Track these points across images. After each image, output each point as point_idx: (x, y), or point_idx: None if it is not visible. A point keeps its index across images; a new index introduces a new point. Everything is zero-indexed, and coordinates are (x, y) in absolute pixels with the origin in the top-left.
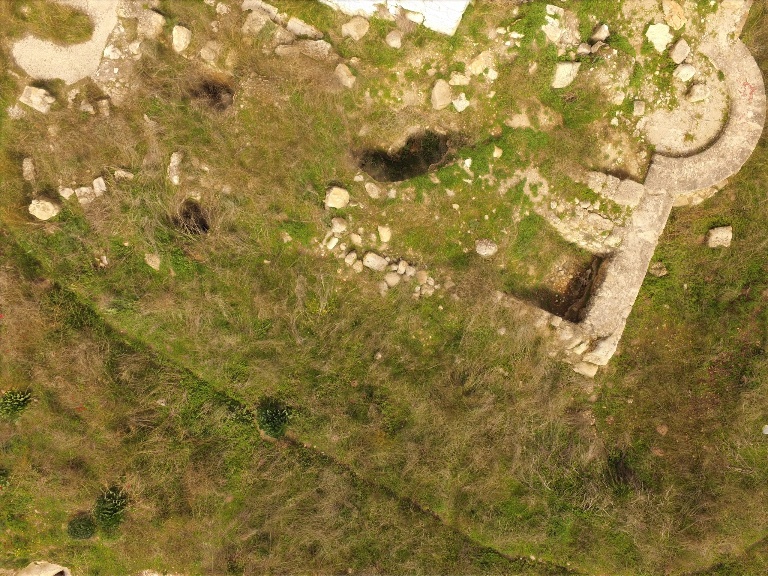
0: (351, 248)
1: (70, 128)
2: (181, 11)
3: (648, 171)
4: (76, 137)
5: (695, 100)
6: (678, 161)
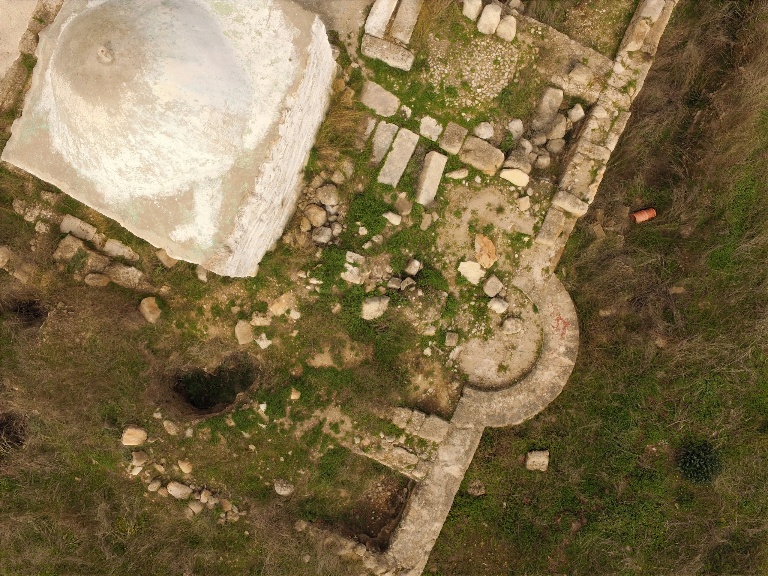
0: (157, 474)
1: None
2: (0, 228)
3: (457, 404)
4: None
5: None
6: (487, 395)
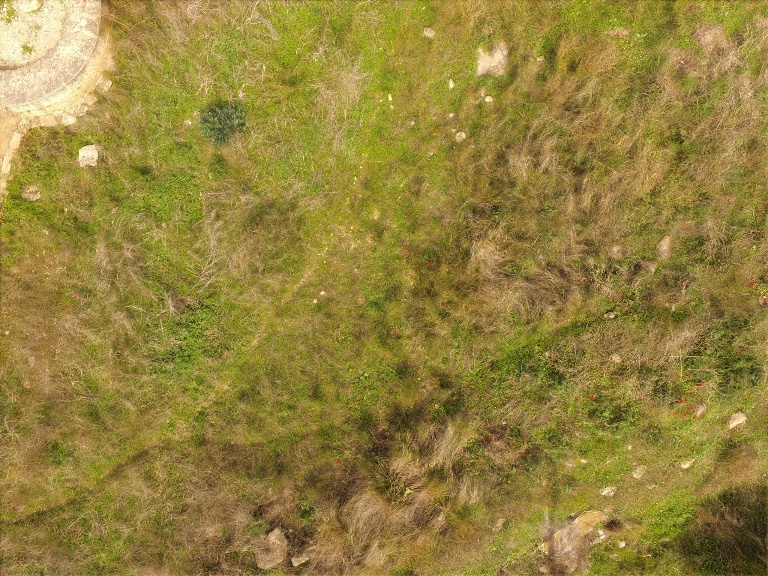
0: None
1: None
2: None
3: None
4: None
5: (27, 10)
6: (5, 73)
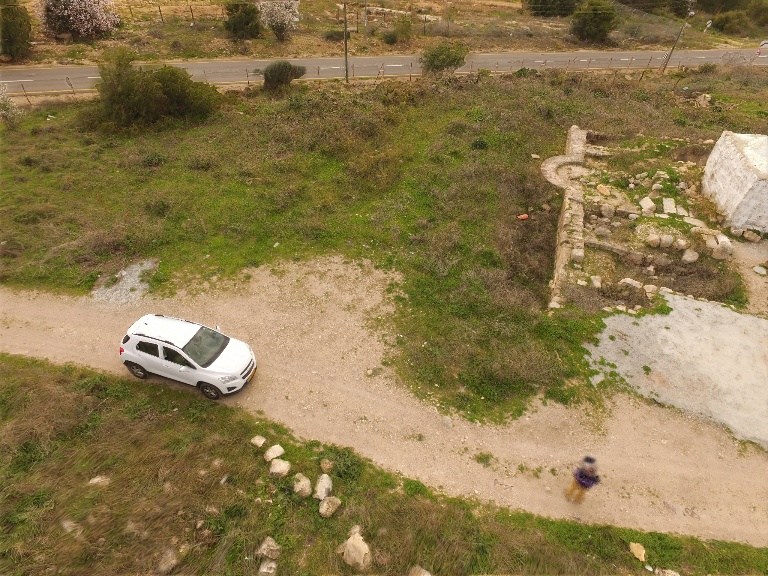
0: None
1: None
2: None
3: None
4: None
5: None
6: None
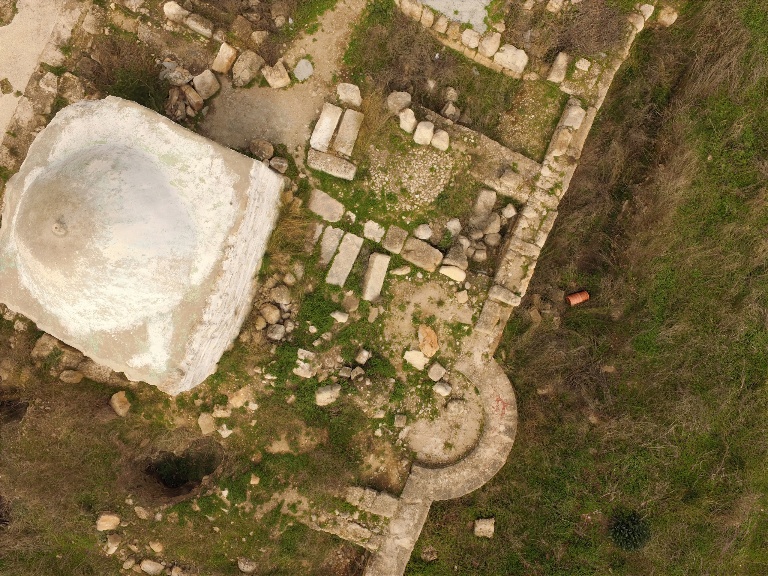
0: (131, 552)
1: None
2: None
3: (406, 481)
4: None
5: None
6: (434, 472)
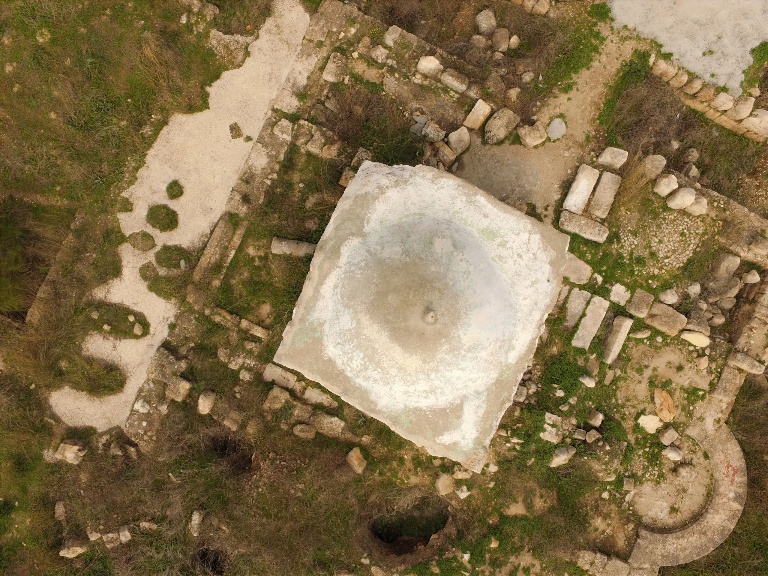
0: None
1: (100, 474)
2: (207, 376)
3: (634, 545)
4: (105, 483)
5: None
6: (663, 537)
